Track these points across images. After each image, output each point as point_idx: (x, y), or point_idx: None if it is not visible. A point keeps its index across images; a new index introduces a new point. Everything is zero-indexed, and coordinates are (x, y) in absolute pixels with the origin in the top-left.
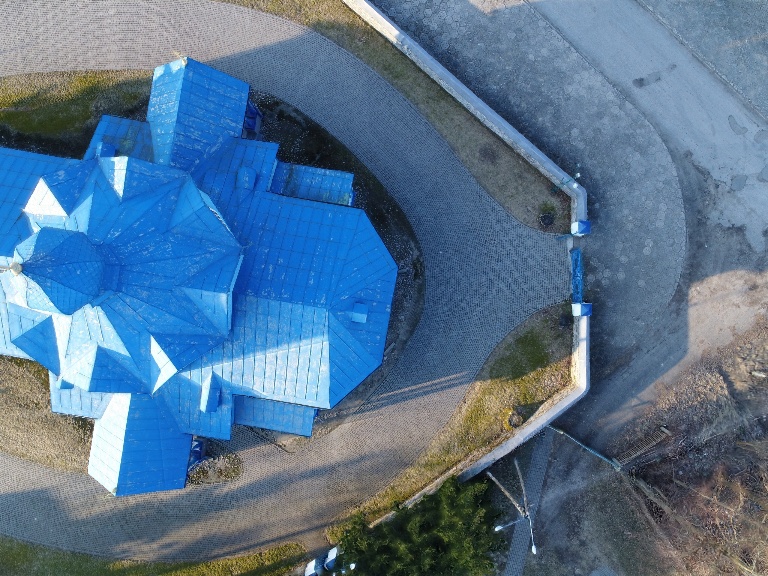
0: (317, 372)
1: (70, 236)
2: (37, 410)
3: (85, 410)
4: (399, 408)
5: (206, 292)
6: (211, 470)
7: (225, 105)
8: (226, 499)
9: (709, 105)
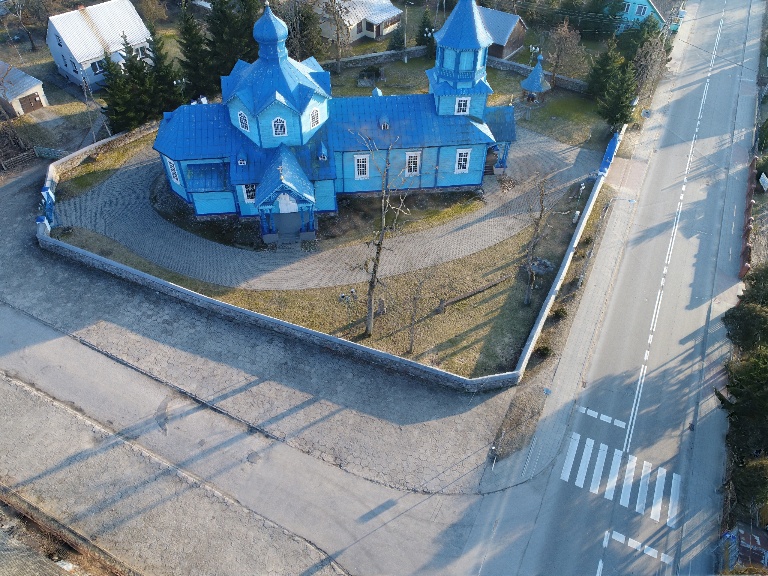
0: None
1: (263, 31)
2: None
3: None
4: None
5: (231, 76)
6: None
7: None
8: None
9: None
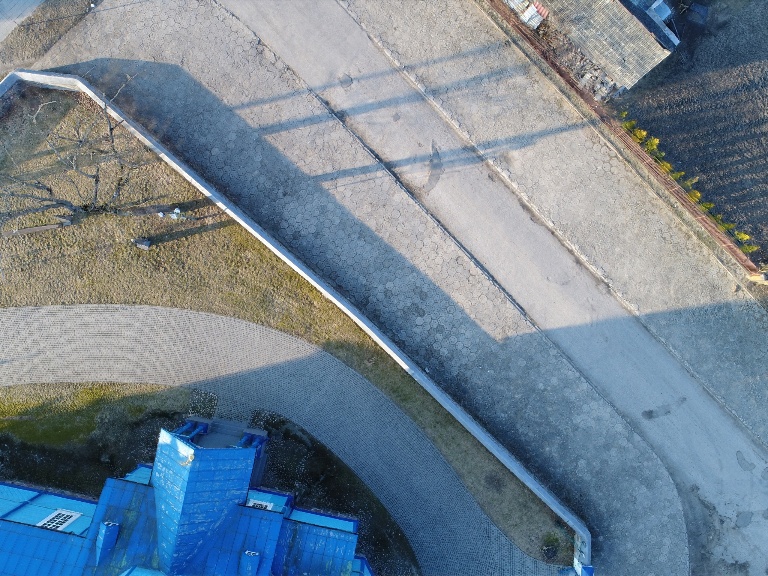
0: None
1: None
2: None
3: None
4: None
5: None
6: None
7: (231, 478)
8: None
9: (718, 440)
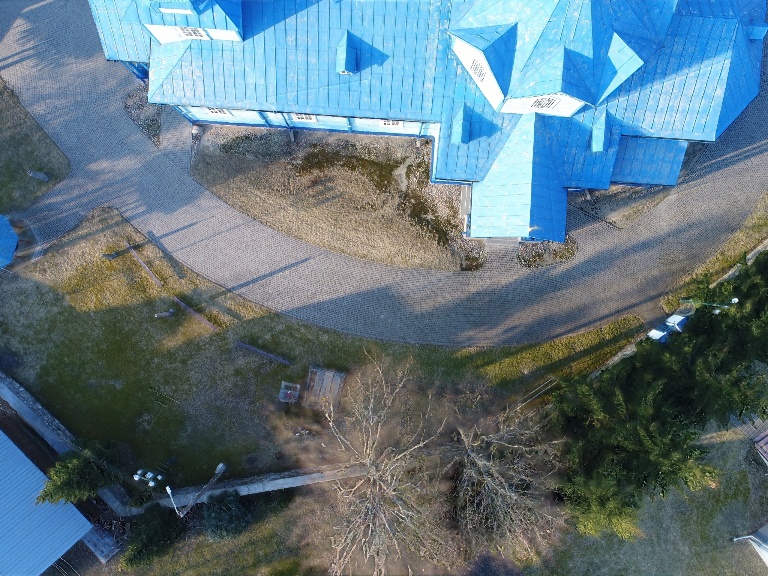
0: (711, 98)
1: None
2: (373, 211)
3: (469, 172)
4: (722, 175)
5: None
6: (546, 253)
7: None
8: (563, 279)
9: None
